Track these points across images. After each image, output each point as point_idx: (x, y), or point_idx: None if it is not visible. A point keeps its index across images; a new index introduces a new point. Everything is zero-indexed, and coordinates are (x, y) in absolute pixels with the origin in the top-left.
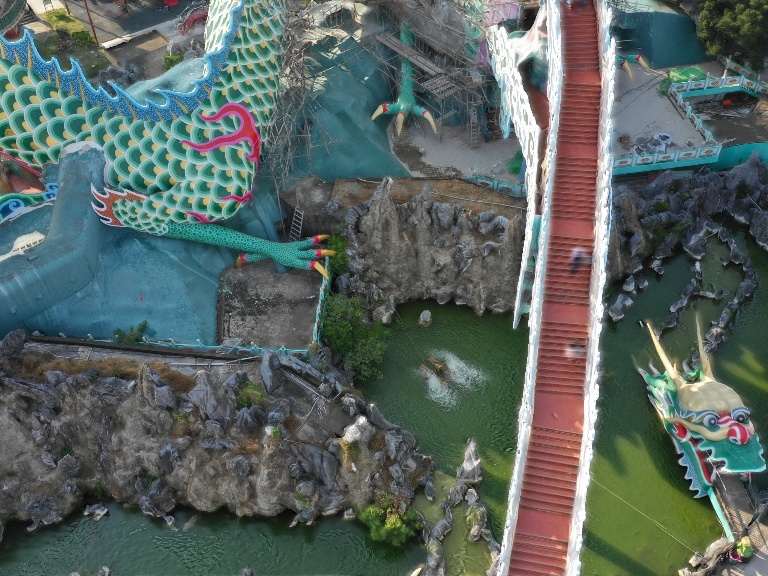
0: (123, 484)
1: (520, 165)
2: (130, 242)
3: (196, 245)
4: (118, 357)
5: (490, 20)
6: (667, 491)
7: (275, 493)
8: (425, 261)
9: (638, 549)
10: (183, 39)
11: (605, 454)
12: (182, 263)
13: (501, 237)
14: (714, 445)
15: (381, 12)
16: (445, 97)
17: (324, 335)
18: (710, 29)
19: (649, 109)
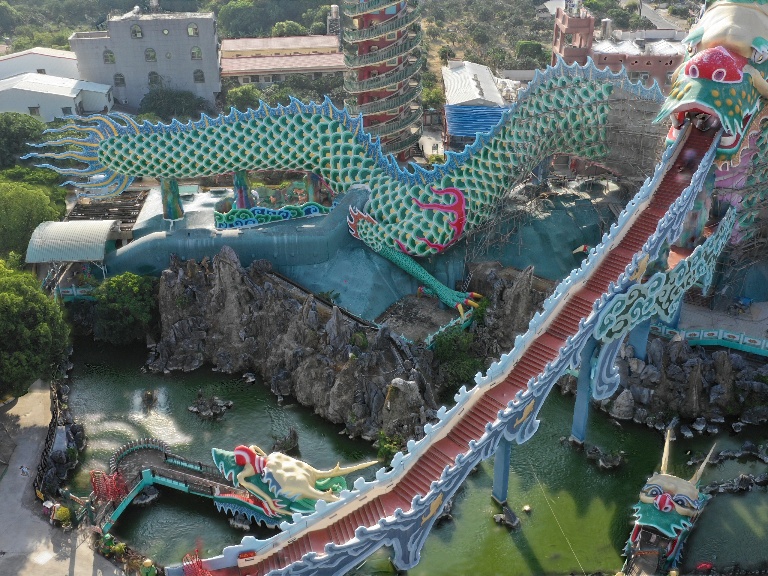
0: (269, 366)
1: None
2: (359, 250)
3: (398, 270)
4: None
5: None
6: (604, 543)
7: (340, 404)
8: None
9: (546, 556)
10: None
11: (578, 502)
12: (382, 274)
13: None
14: (642, 505)
15: None
16: None
17: (435, 343)
18: None
19: None
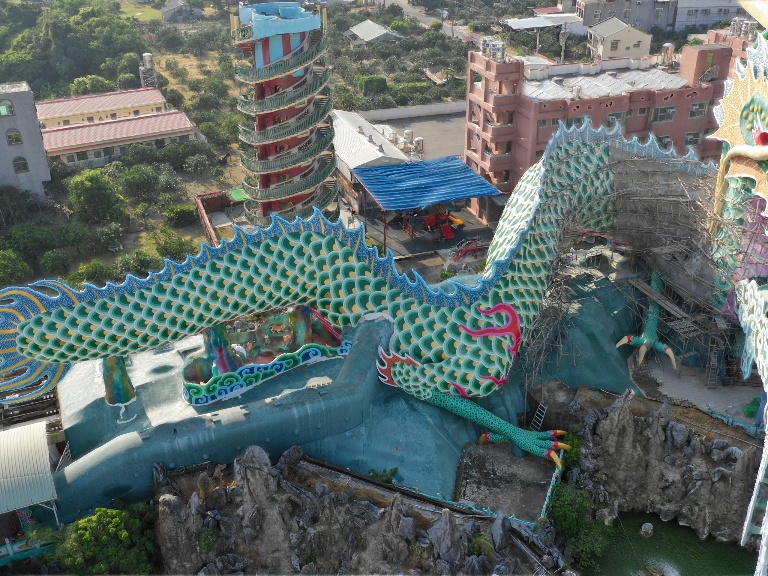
0: None
1: (756, 410)
2: (397, 400)
3: (449, 416)
4: (371, 489)
5: (741, 276)
6: None
7: None
8: (654, 474)
9: None
10: (454, 264)
11: None
12: (435, 427)
13: (733, 467)
14: None
15: (635, 262)
16: (689, 337)
17: (551, 516)
18: None
19: None
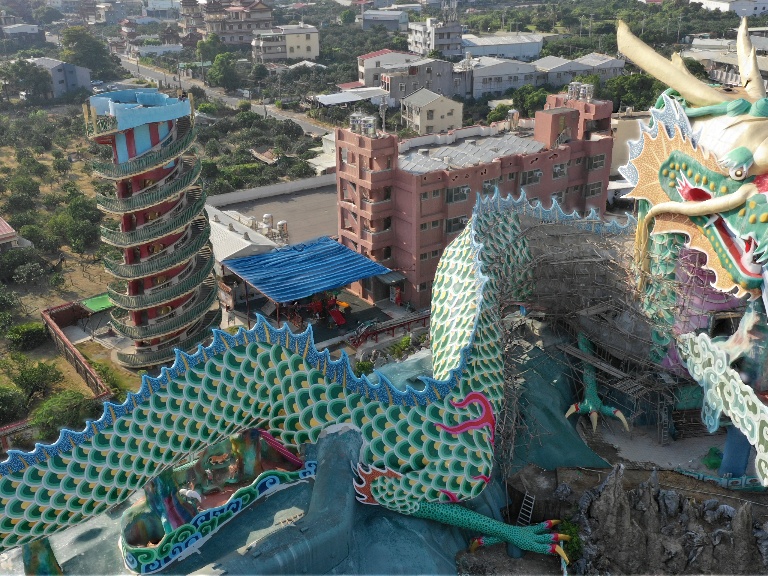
0: None
1: (717, 461)
2: (380, 520)
3: (435, 527)
4: None
5: (681, 329)
6: None
7: None
8: (655, 549)
9: None
10: None
11: None
12: (427, 543)
13: (728, 526)
14: None
15: (556, 327)
16: (639, 397)
17: None
18: None
19: None
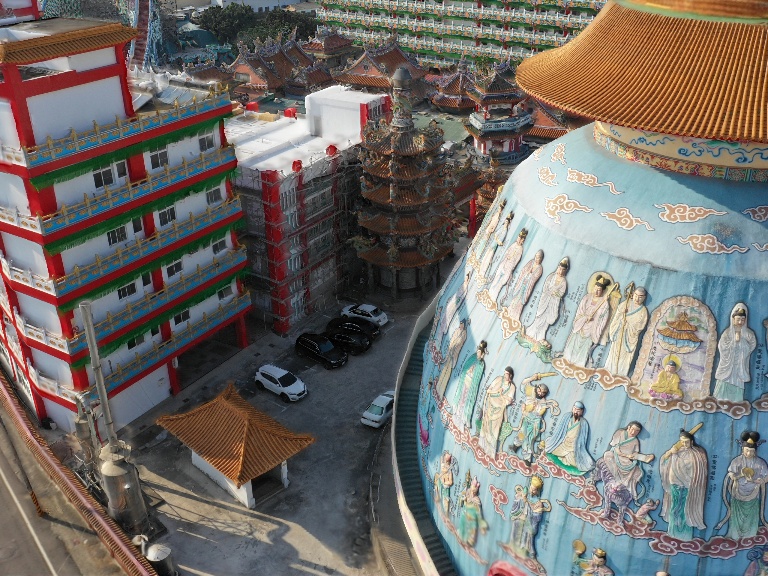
0: None
1: None
2: None
3: None
4: None
5: None
6: None
7: None
8: None
9: None
10: None
11: None
12: None
13: None
14: None
15: None
16: None
17: None
18: (216, 30)
19: (198, 53)
